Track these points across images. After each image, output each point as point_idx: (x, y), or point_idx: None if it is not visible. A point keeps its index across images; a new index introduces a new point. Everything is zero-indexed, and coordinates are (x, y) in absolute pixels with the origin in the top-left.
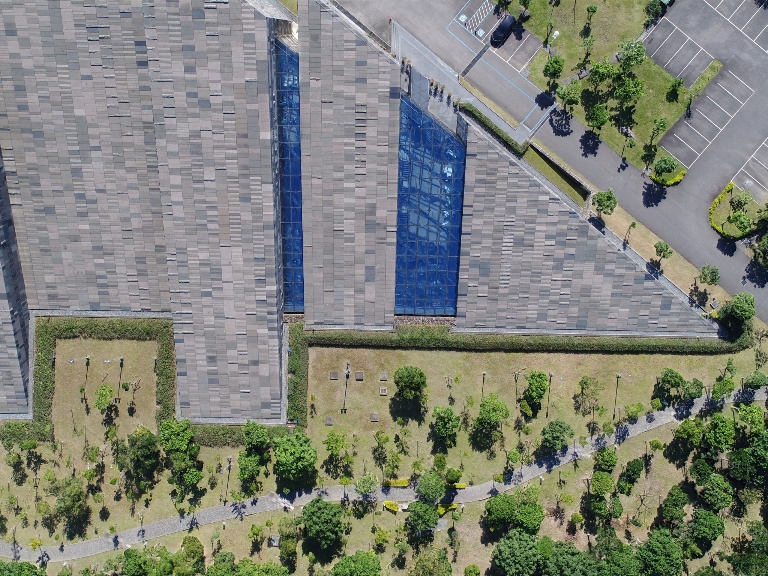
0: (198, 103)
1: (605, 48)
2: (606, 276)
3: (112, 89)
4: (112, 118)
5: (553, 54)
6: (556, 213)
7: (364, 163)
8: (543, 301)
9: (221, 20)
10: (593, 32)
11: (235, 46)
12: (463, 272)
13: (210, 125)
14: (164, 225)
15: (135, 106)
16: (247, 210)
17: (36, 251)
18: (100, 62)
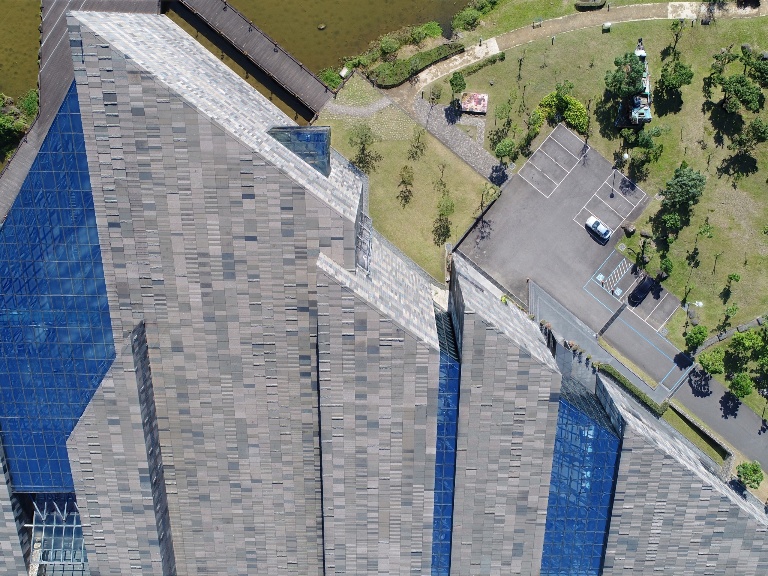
0: (367, 424)
1: (745, 311)
2: (753, 550)
3: (274, 396)
4: (272, 420)
5: (692, 315)
6: (708, 498)
7: (519, 457)
8: (688, 572)
9: (395, 355)
10: (733, 295)
11: (407, 376)
12: (610, 548)
13: (377, 442)
14: (324, 525)
15: (295, 410)
16: (408, 512)
17: (188, 531)
18: (263, 373)
